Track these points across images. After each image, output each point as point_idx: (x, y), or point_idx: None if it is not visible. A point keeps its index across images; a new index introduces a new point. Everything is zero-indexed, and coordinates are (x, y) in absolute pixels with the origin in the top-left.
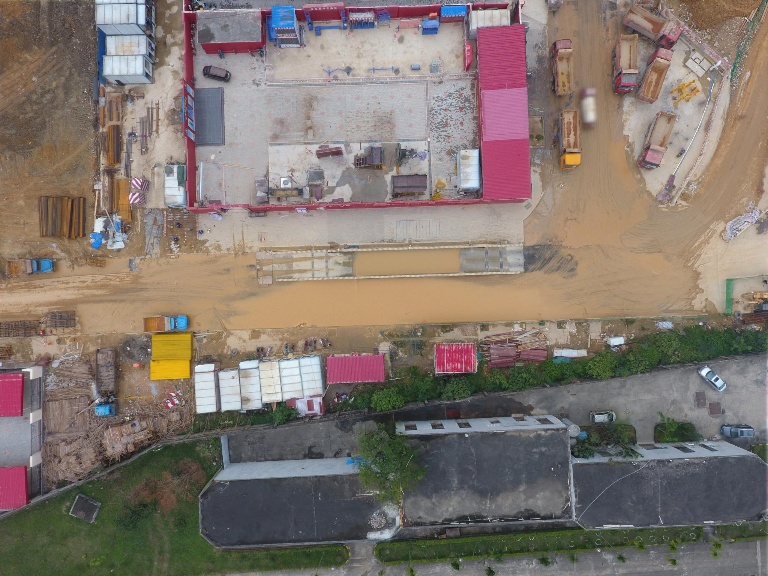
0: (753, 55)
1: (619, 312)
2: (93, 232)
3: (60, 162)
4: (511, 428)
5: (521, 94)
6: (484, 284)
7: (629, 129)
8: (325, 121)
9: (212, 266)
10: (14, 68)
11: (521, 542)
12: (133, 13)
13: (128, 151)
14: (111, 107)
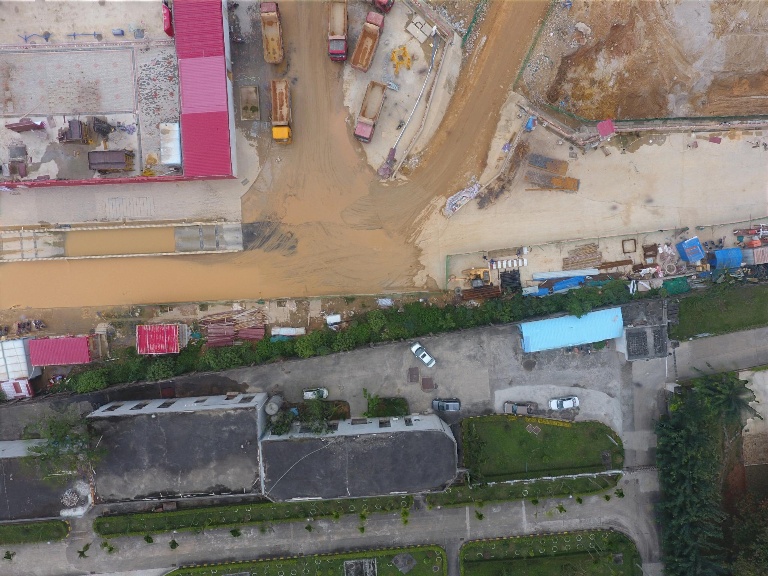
0: (491, 18)
1: (340, 290)
2: None
3: None
4: (201, 408)
5: (218, 63)
6: (202, 263)
7: (349, 100)
8: (25, 92)
9: None
10: None
11: (238, 513)
12: None
13: None
14: None
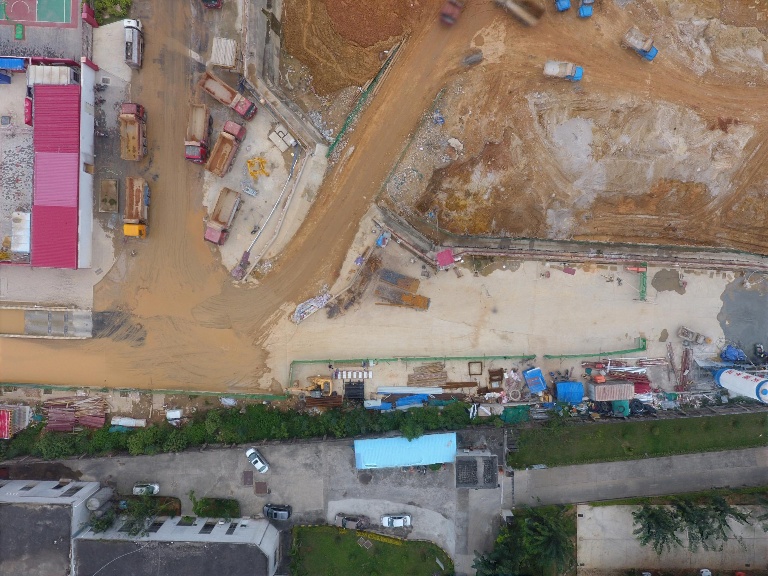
0: (361, 129)
1: (185, 385)
2: None
3: None
4: (18, 500)
5: (72, 160)
6: (51, 347)
7: (208, 200)
8: None
9: None
10: None
11: None
12: None
13: None
14: None
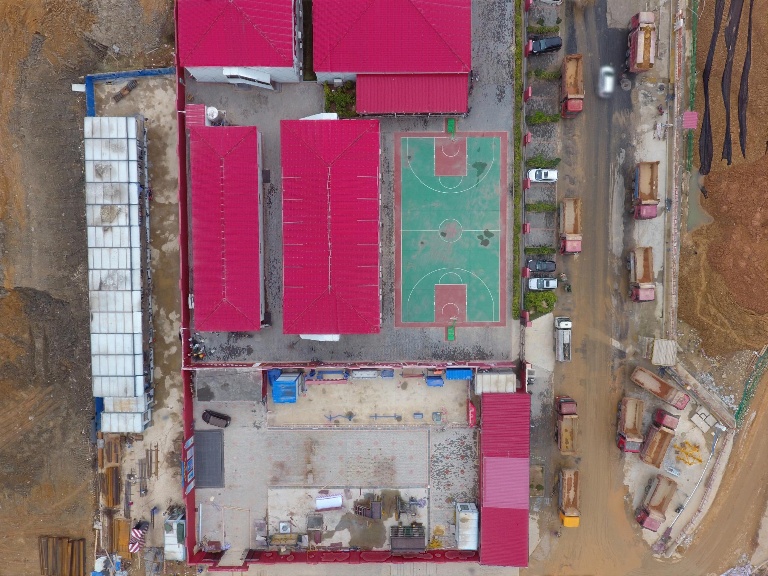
0: (760, 394)
1: None
2: (93, 571)
3: (59, 502)
4: None
5: (523, 464)
6: None
7: (629, 480)
8: (325, 466)
9: None
10: (10, 406)
11: None
12: (131, 386)
13: (127, 493)
14: (110, 449)
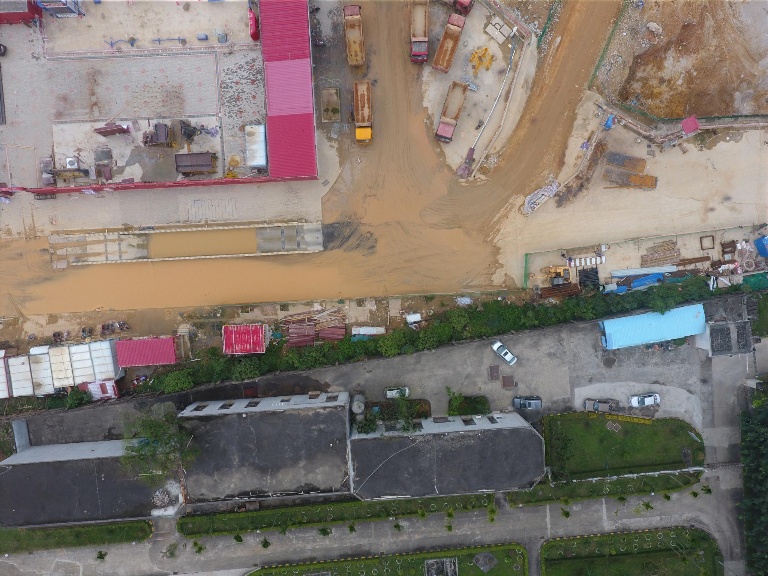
0: (565, 19)
1: (419, 289)
2: None
3: None
4: (290, 407)
5: (304, 65)
6: (283, 263)
7: (428, 100)
8: (110, 97)
9: (4, 251)
10: None
11: (320, 513)
12: None
13: None
14: None
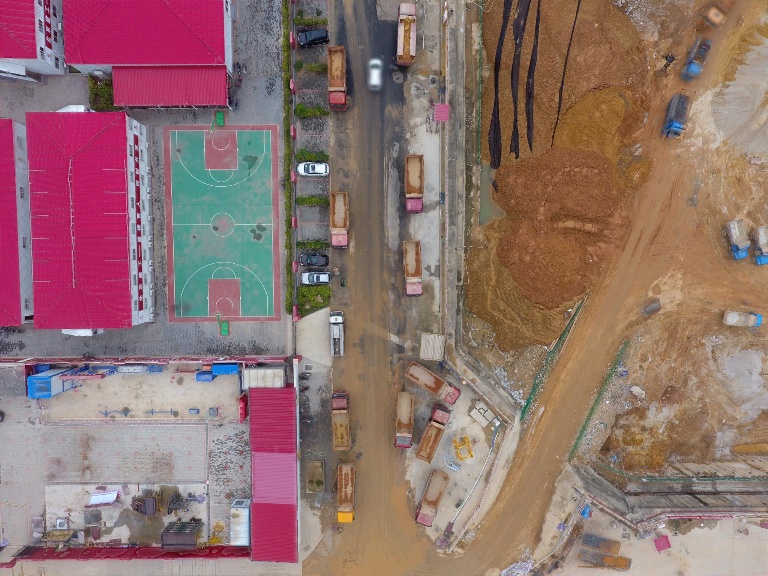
0: (549, 389)
1: None
2: None
3: None
4: None
5: (290, 459)
6: None
7: (411, 475)
8: (103, 461)
9: None
10: None
11: None
12: None
13: None
14: None
